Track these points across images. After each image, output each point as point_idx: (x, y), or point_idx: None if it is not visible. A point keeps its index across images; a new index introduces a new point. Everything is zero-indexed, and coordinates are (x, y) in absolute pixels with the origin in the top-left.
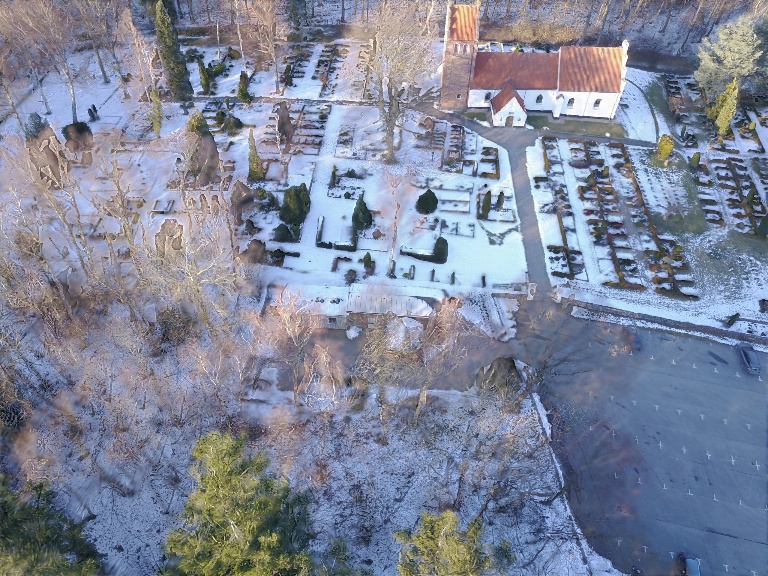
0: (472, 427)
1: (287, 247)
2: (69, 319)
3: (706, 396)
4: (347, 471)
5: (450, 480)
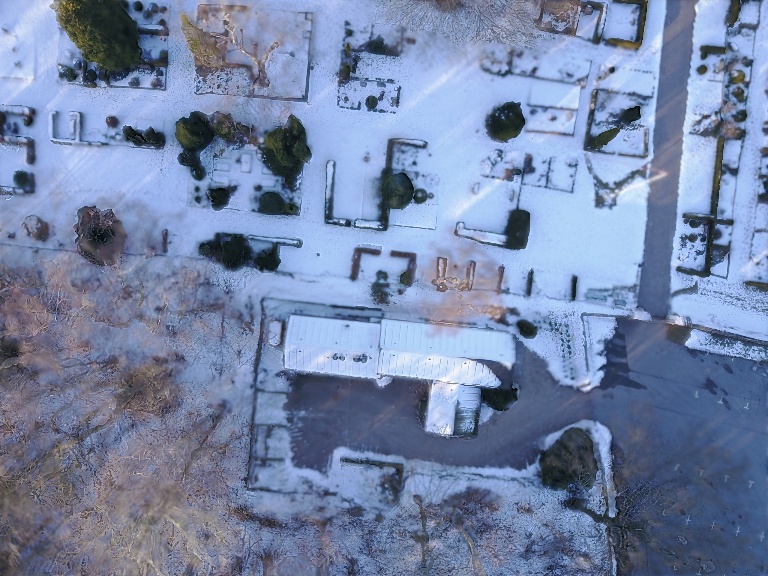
0: (526, 526)
1: (281, 225)
2: (1, 393)
3: None
4: (381, 567)
5: (493, 574)
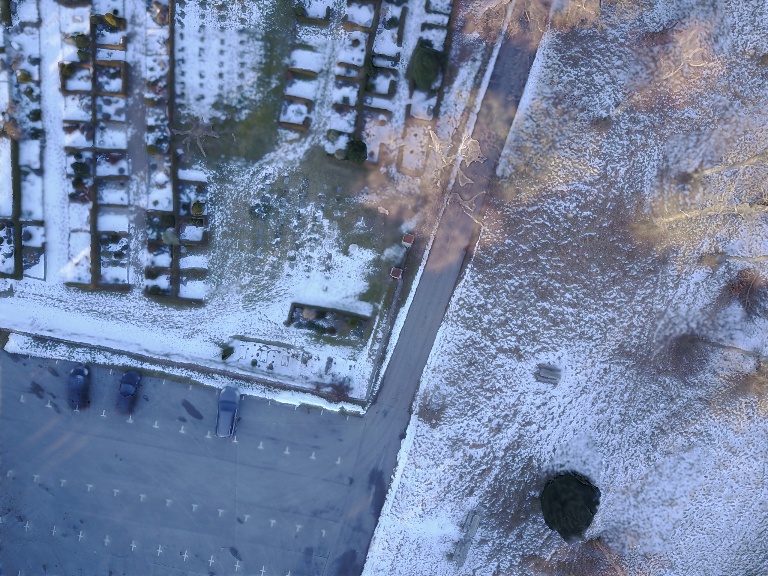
0: None
1: None
2: None
3: (156, 469)
4: None
5: None
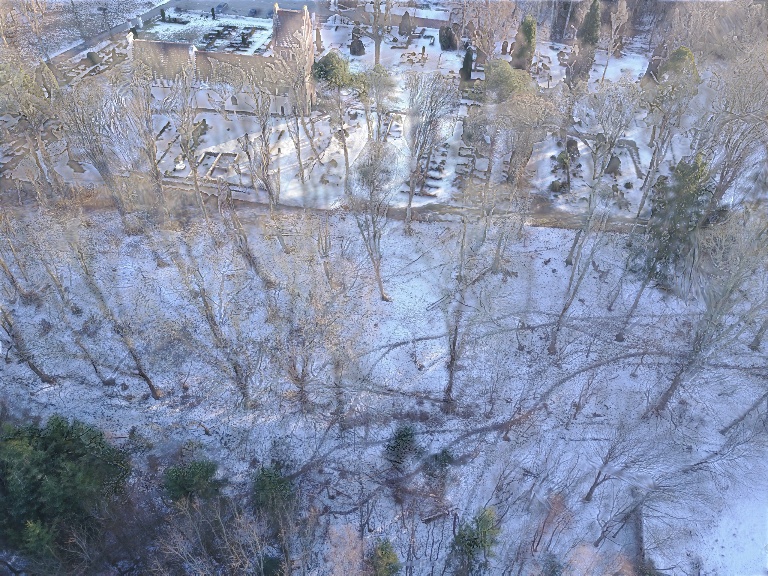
0: None
1: None
2: None
3: (255, 4)
4: None
5: None
